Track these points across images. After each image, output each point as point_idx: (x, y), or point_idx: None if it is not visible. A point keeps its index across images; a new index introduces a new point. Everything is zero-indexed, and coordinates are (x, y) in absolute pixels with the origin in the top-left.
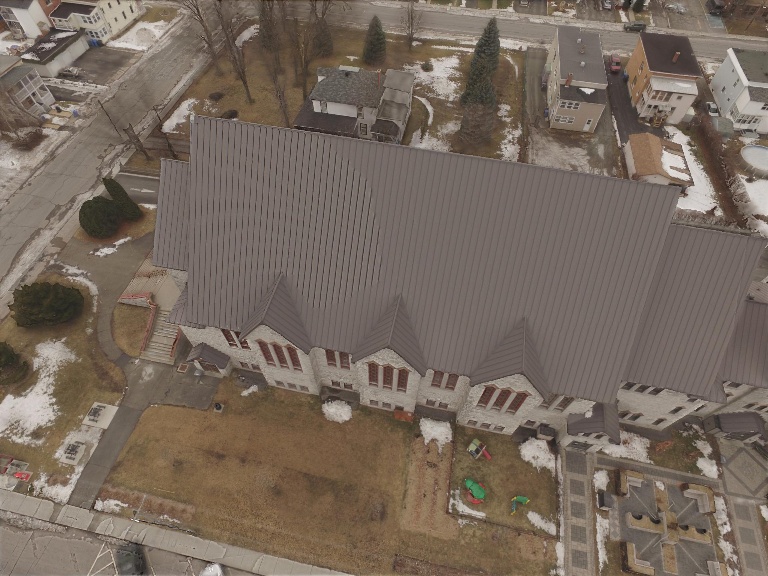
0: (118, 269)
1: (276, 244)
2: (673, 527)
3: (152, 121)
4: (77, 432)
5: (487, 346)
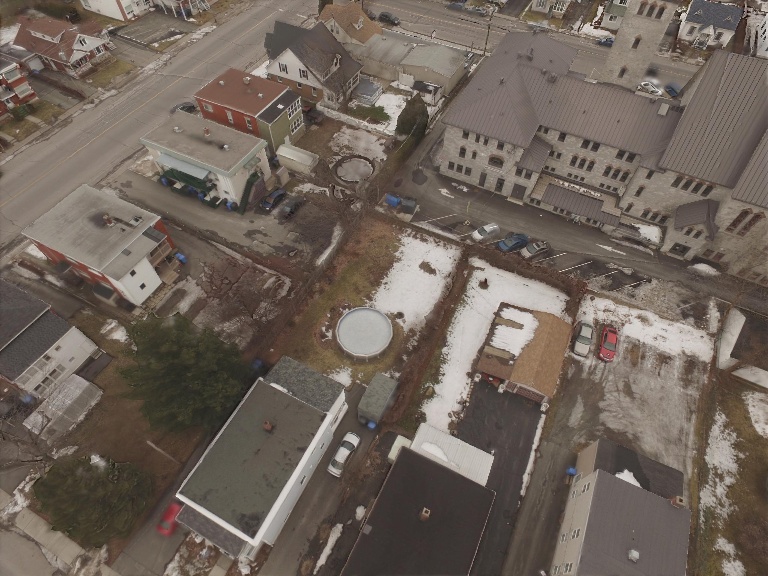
0: None
1: None
2: None
3: None
4: None
5: None
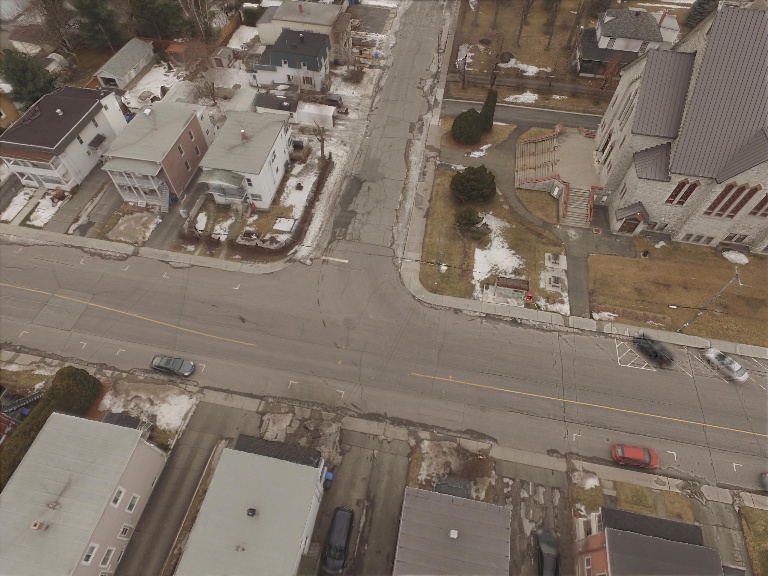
0: (498, 166)
1: (764, 105)
2: None
3: (442, 61)
4: (546, 271)
5: None
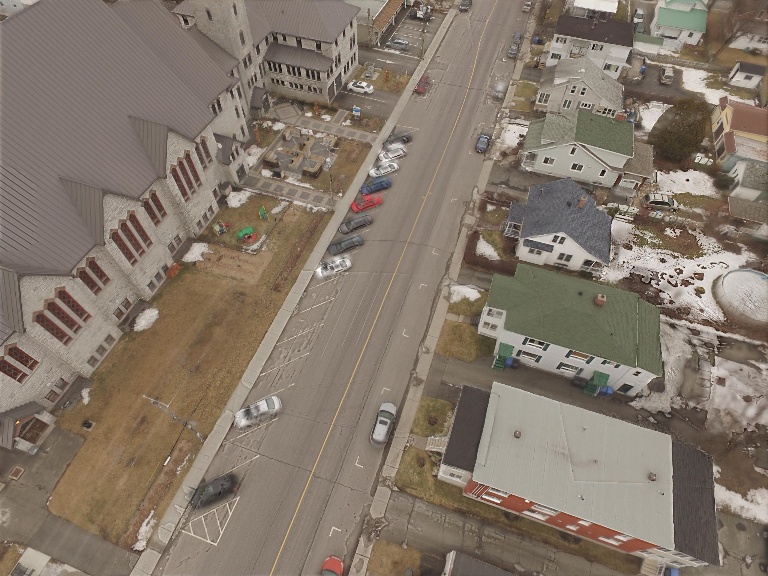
0: None
1: None
2: (301, 148)
3: None
4: None
5: (139, 151)
